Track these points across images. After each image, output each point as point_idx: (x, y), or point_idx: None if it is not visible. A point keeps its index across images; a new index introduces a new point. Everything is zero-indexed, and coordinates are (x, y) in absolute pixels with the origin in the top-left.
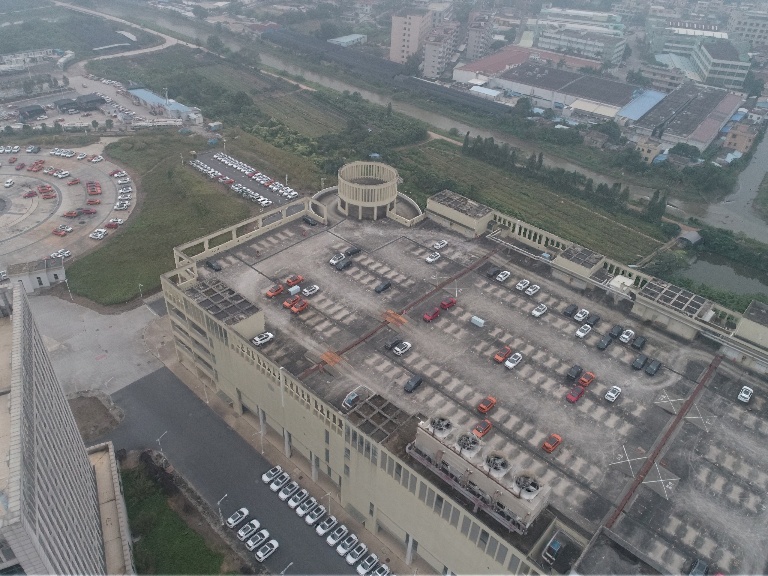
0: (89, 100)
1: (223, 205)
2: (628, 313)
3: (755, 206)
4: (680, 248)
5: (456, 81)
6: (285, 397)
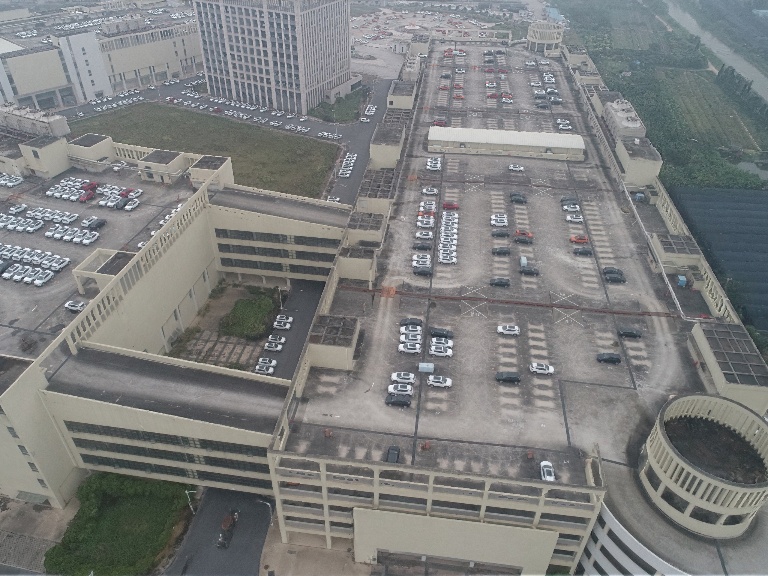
0: (517, 6)
1: None
2: (578, 99)
3: None
4: None
5: None
6: None
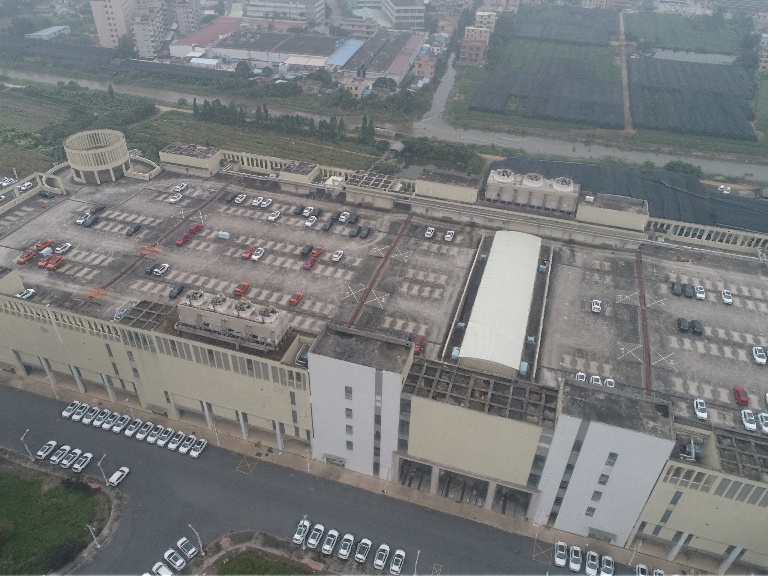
0: None
1: None
2: (344, 202)
3: (444, 117)
4: (392, 158)
5: (174, 56)
6: (60, 333)
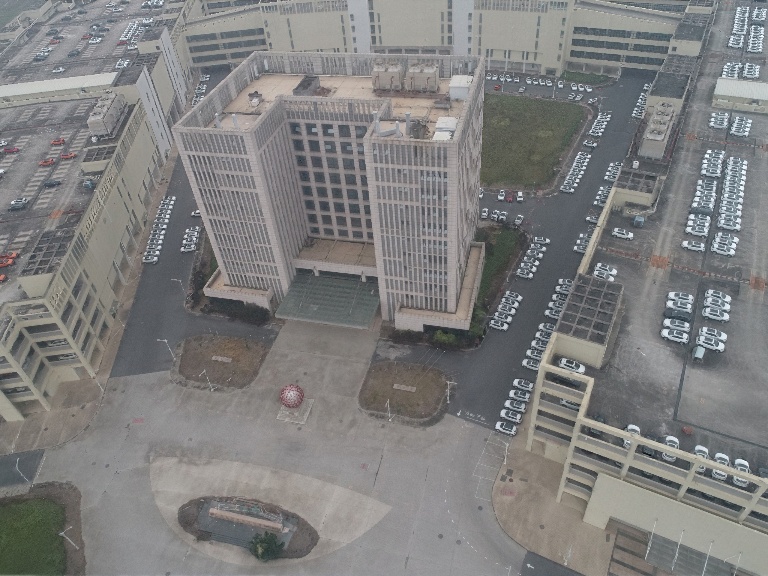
0: None
1: None
2: None
3: None
4: None
5: None
6: None
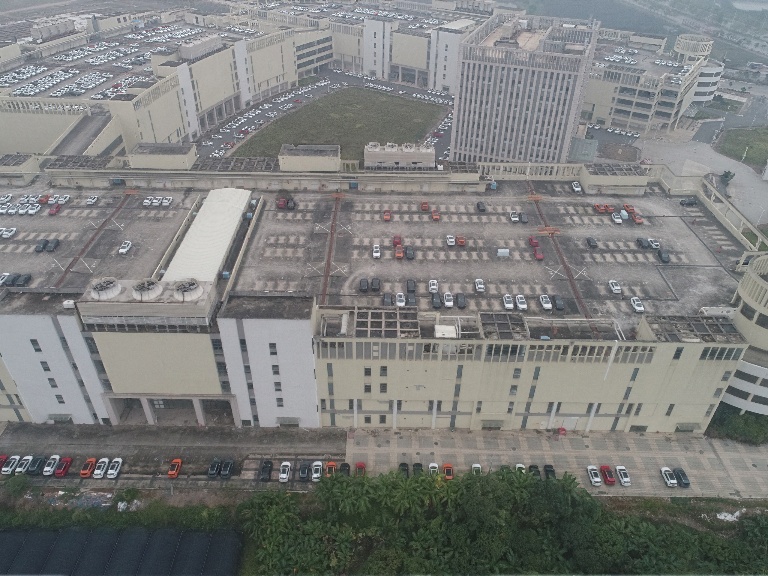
0: None
1: None
2: None
3: None
4: None
5: None
6: None
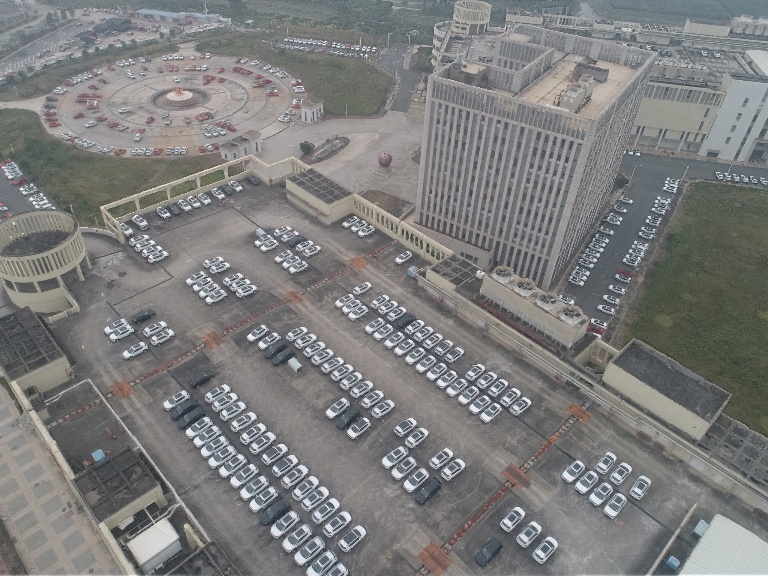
0: (122, 21)
1: (343, 62)
2: (637, 42)
3: (598, 13)
4: None
5: None
6: None
